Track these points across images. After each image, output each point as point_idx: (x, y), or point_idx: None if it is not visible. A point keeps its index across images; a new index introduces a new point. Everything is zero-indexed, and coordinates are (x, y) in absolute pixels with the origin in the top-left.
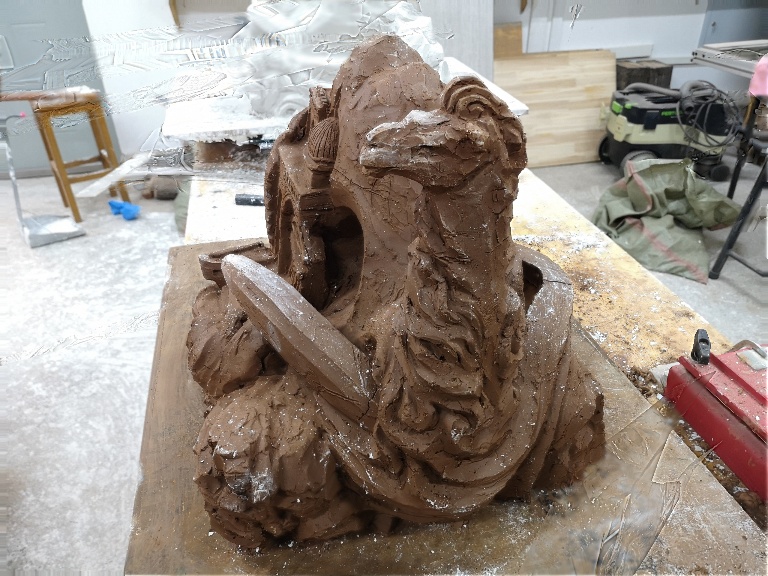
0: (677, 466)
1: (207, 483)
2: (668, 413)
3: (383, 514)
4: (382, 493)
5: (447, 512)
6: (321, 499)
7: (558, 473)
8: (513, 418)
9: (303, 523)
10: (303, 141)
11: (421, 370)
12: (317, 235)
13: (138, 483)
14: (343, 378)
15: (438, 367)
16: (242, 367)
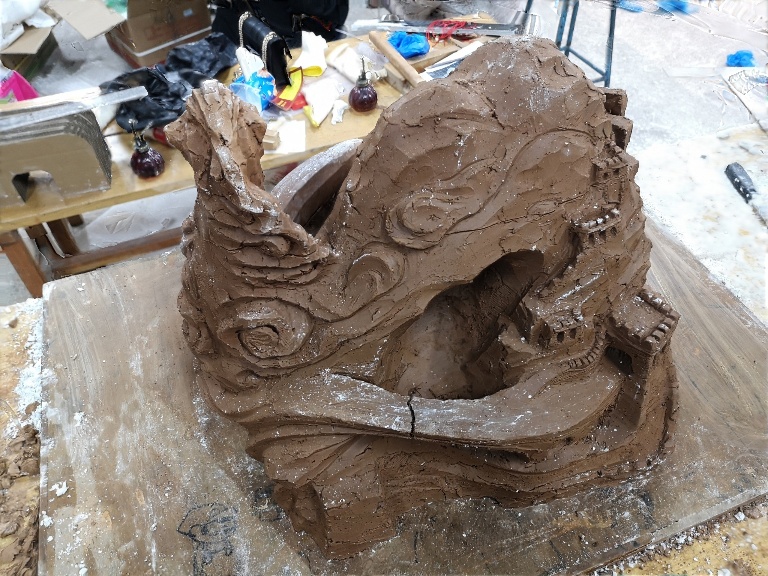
0: None
1: None
2: None
3: None
4: None
5: None
6: None
7: None
8: (244, 392)
9: None
10: None
11: None
12: None
13: None
14: None
15: None
16: None
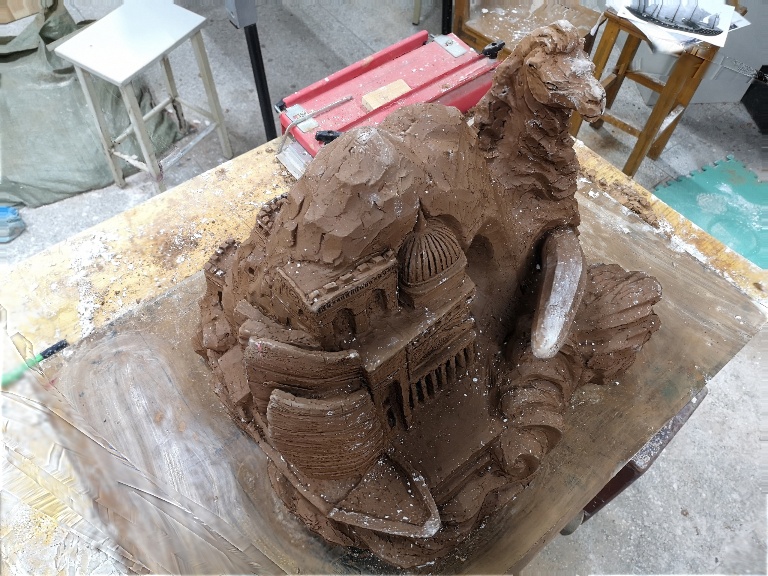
0: None
1: None
2: (657, 25)
3: None
4: None
5: None
6: None
7: None
8: None
9: None
10: (345, 347)
11: (574, 179)
12: None
13: (625, 462)
14: None
15: None
16: None
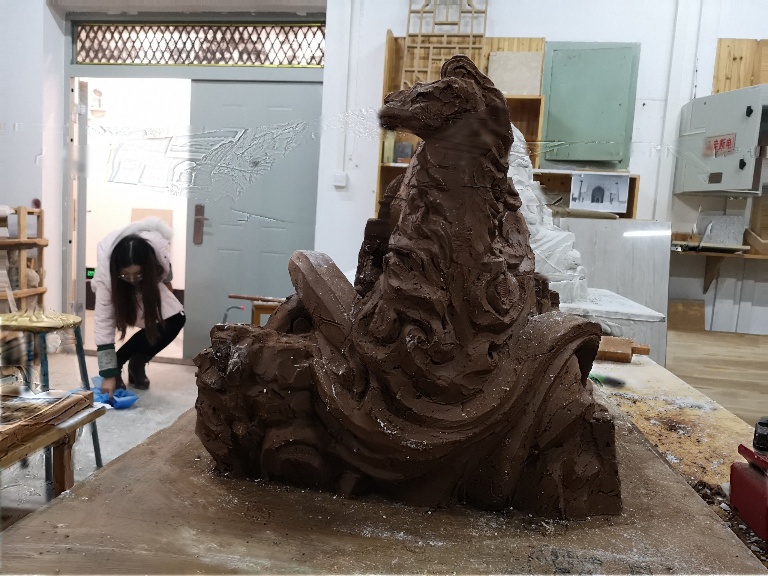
0: (710, 540)
1: (201, 362)
2: None
3: (350, 474)
4: (340, 407)
5: (396, 441)
6: (286, 403)
7: (547, 489)
8: (488, 382)
9: (267, 434)
10: None
11: (392, 280)
12: (378, 267)
13: (165, 426)
14: (338, 306)
15: (405, 275)
16: (275, 324)
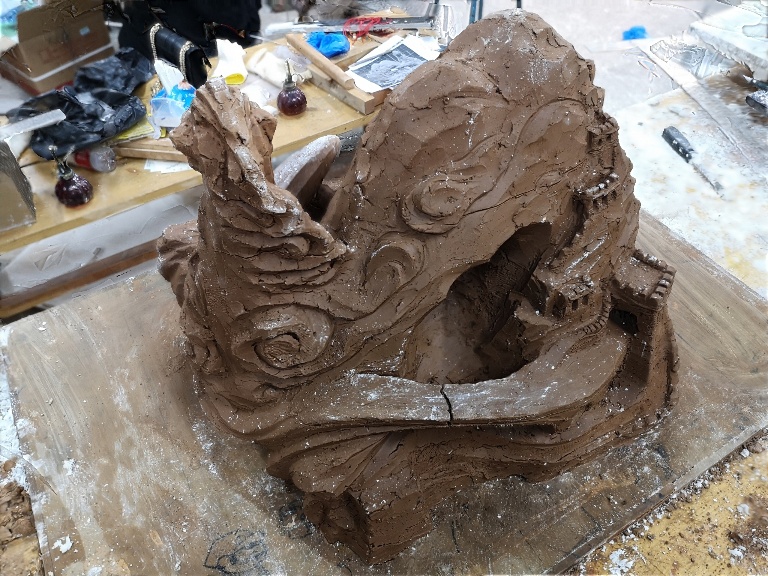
0: None
1: None
2: None
3: None
4: None
5: None
6: None
7: None
8: (261, 408)
9: None
10: None
11: None
12: None
13: None
14: None
15: None
16: None
